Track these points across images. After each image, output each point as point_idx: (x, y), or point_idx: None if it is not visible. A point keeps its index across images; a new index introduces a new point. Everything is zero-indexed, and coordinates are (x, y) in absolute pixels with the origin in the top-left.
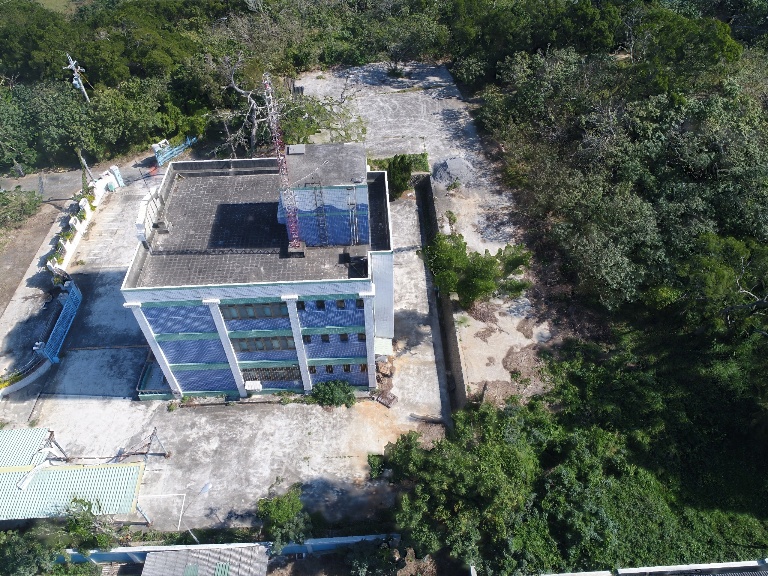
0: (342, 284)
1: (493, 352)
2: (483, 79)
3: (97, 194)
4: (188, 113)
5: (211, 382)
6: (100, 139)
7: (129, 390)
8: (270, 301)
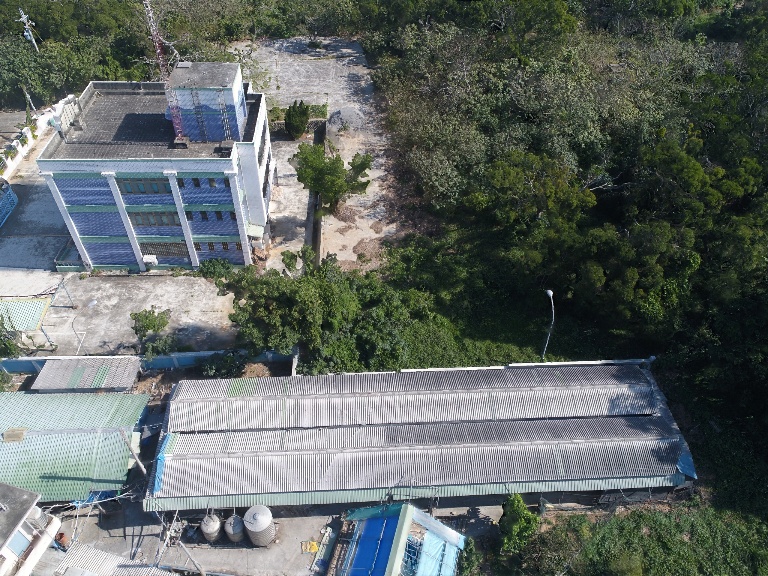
0: (210, 163)
1: (347, 242)
2: (385, 50)
3: (39, 126)
4: (127, 67)
5: (116, 256)
6: (46, 84)
7: (49, 265)
8: (156, 177)
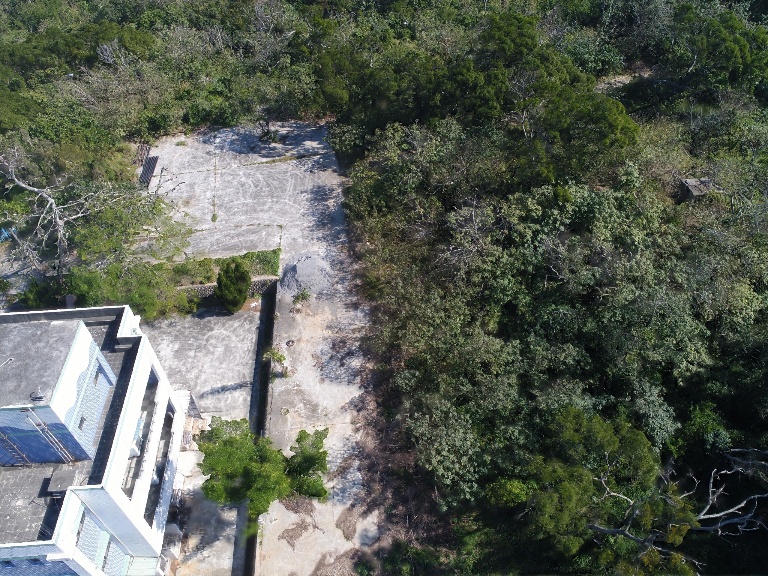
0: (15, 549)
1: (298, 564)
2: (361, 149)
3: None
4: (9, 197)
5: None
6: None
7: None
8: None
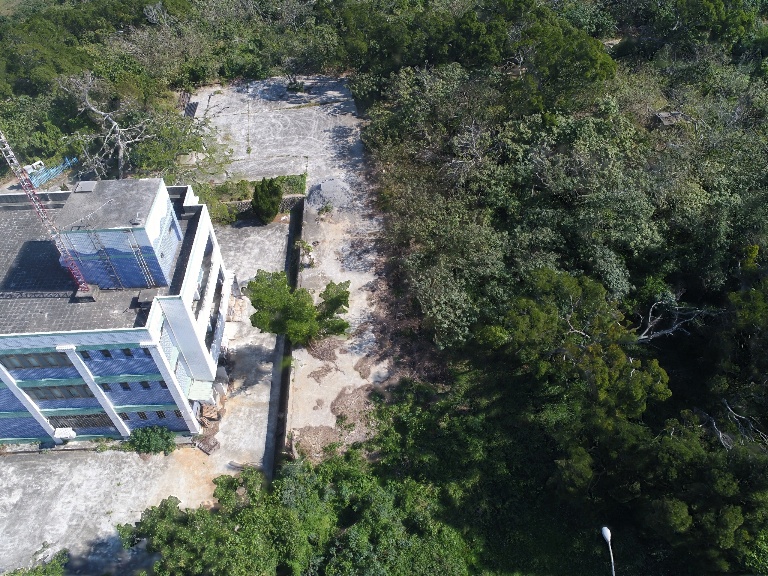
0: (118, 334)
1: (324, 394)
2: (377, 94)
3: None
4: (70, 132)
5: (20, 429)
6: None
7: None
8: (48, 351)
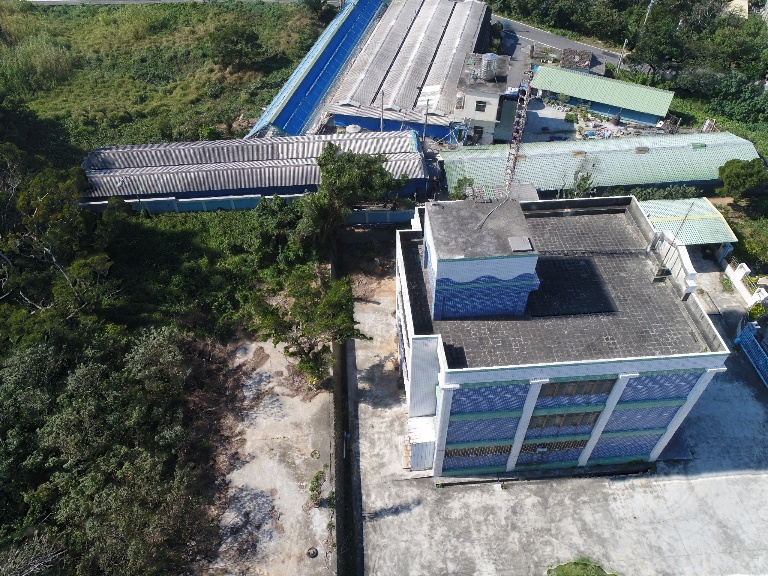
0: None
1: None
2: None
3: None
4: None
5: None
6: None
7: None
8: None
